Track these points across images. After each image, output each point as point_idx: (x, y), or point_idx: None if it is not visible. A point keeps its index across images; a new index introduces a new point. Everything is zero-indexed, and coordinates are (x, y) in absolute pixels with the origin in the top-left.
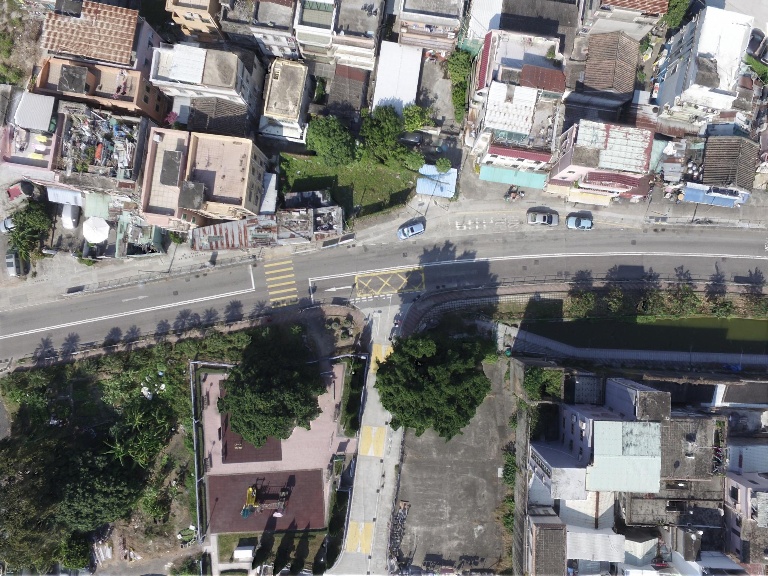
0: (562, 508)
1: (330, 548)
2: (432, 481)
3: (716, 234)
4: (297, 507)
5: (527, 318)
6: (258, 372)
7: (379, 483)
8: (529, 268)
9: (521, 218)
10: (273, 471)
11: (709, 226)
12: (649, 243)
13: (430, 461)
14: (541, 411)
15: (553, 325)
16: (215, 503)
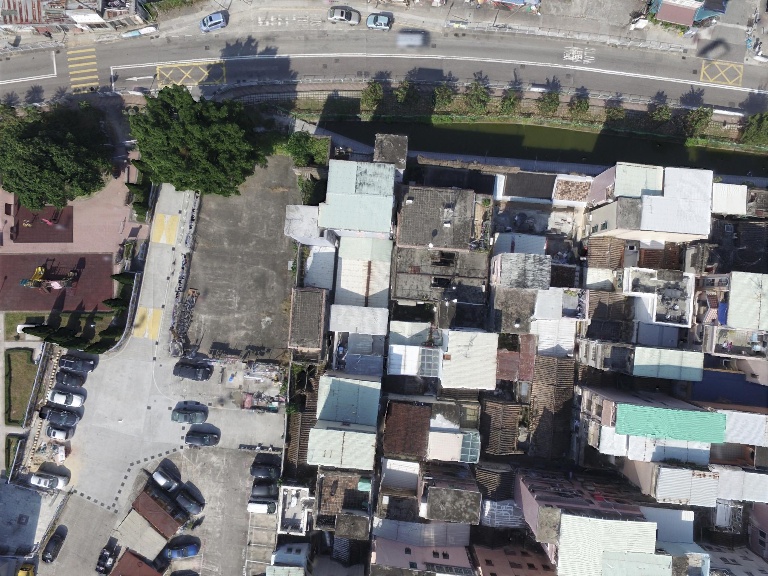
0: (337, 290)
1: (113, 327)
2: (222, 271)
3: (516, 41)
4: (86, 289)
5: (324, 114)
6: (28, 128)
7: (170, 270)
8: (329, 66)
9: (323, 17)
10: (63, 252)
11: (508, 32)
12: (449, 47)
13: (221, 251)
14: (316, 189)
15: (351, 124)
16: (4, 281)
